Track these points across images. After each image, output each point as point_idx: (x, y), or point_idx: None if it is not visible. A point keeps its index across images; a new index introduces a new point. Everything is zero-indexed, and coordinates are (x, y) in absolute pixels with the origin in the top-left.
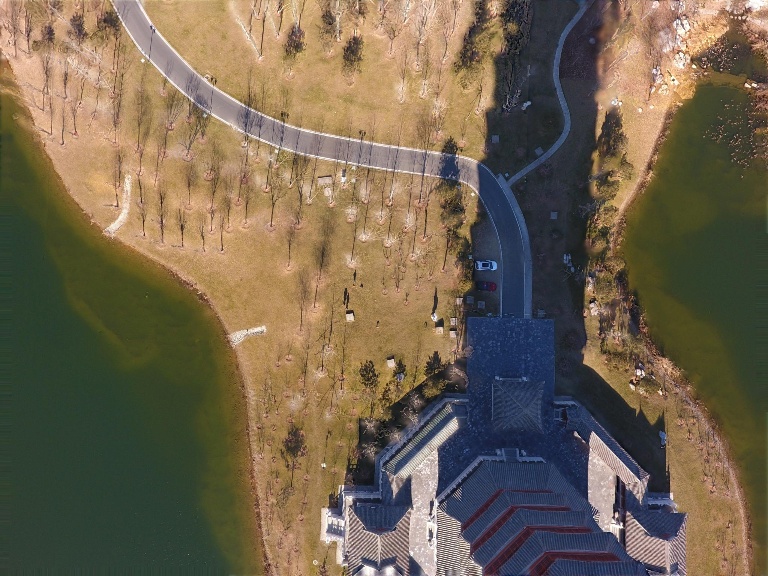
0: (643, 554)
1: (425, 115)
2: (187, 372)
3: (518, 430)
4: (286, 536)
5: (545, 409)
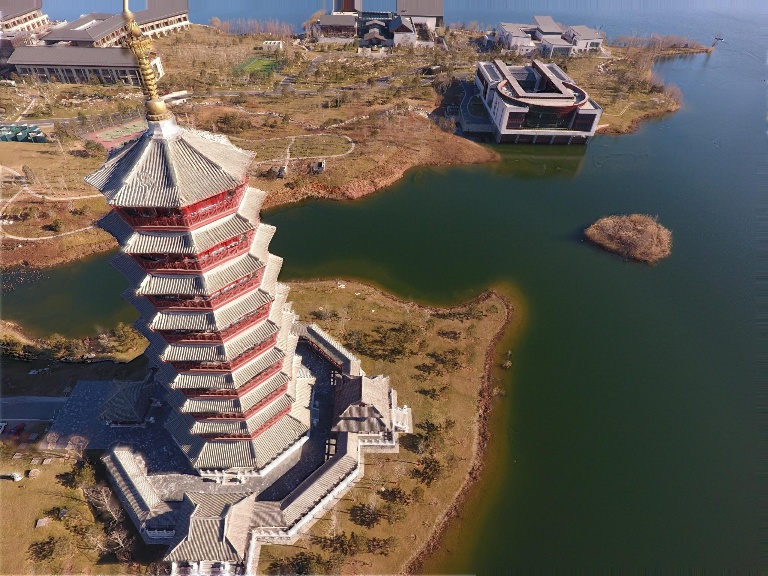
0: None
1: None
2: None
3: (161, 407)
4: None
5: None
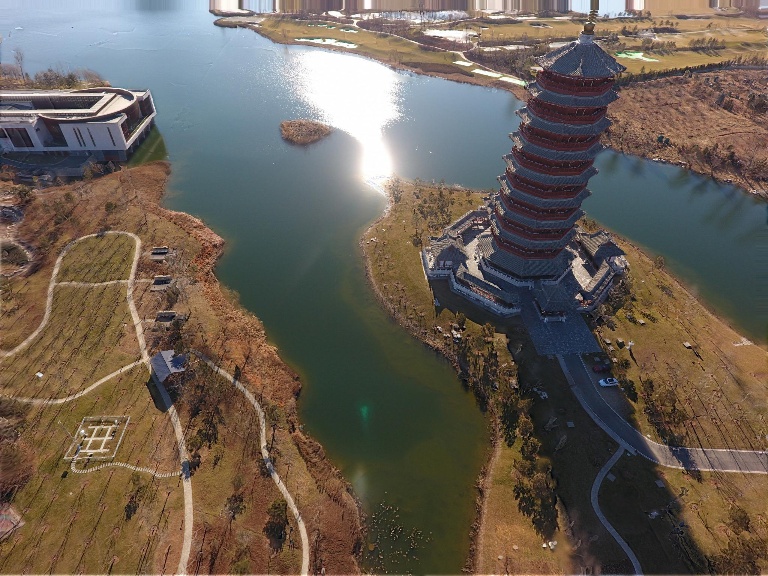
0: (458, 244)
1: (742, 500)
2: (760, 326)
3: None
4: (640, 257)
5: (524, 308)
